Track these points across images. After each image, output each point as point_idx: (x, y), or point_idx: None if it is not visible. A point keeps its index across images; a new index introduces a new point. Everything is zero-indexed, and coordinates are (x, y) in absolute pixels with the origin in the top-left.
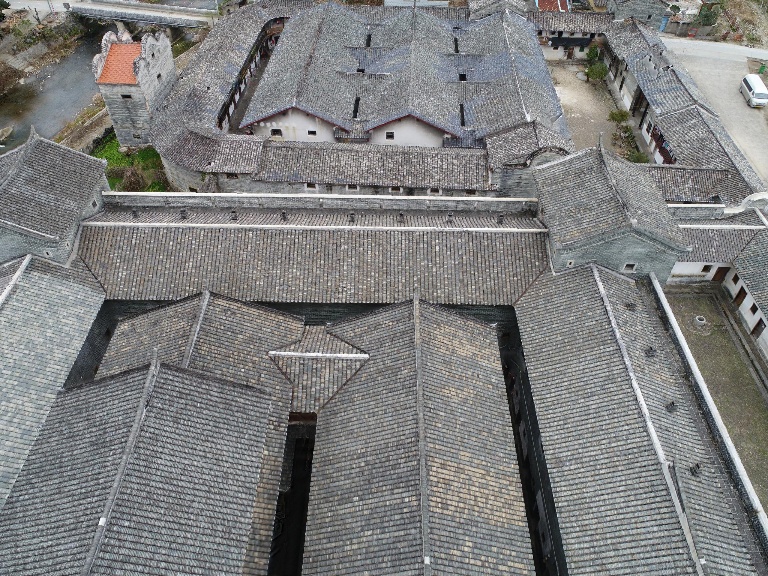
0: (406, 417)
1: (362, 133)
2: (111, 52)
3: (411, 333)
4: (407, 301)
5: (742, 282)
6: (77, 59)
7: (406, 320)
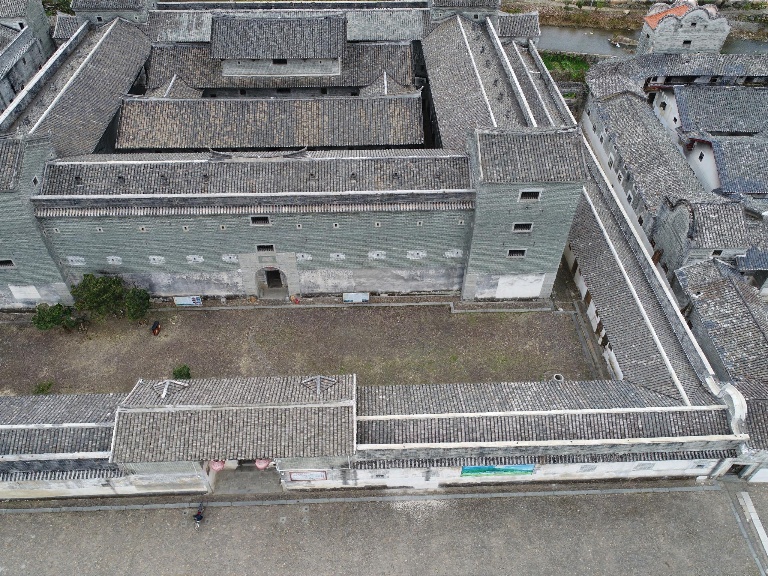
0: None
1: (688, 139)
2: (676, 8)
3: None
4: None
5: None
6: (757, 45)
7: None
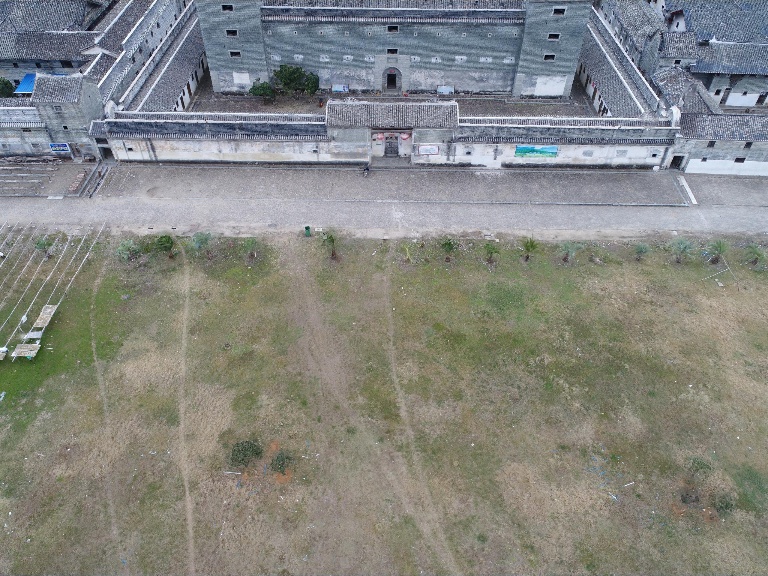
0: None
1: None
2: None
3: None
4: None
5: None
6: None
7: None
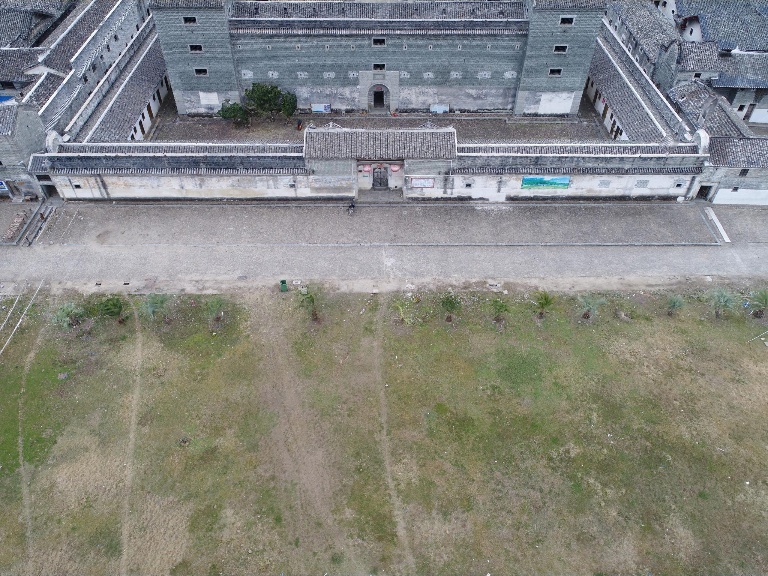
0: None
1: (682, 21)
2: None
3: None
4: None
5: None
6: None
7: None
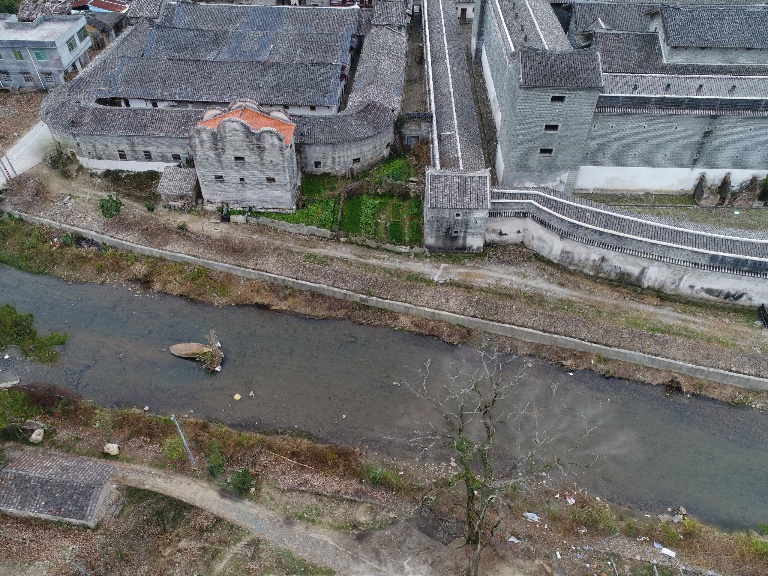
0: (628, 7)
1: None
2: None
3: (590, 4)
4: (574, 4)
5: (461, 7)
6: None
7: (583, 6)
